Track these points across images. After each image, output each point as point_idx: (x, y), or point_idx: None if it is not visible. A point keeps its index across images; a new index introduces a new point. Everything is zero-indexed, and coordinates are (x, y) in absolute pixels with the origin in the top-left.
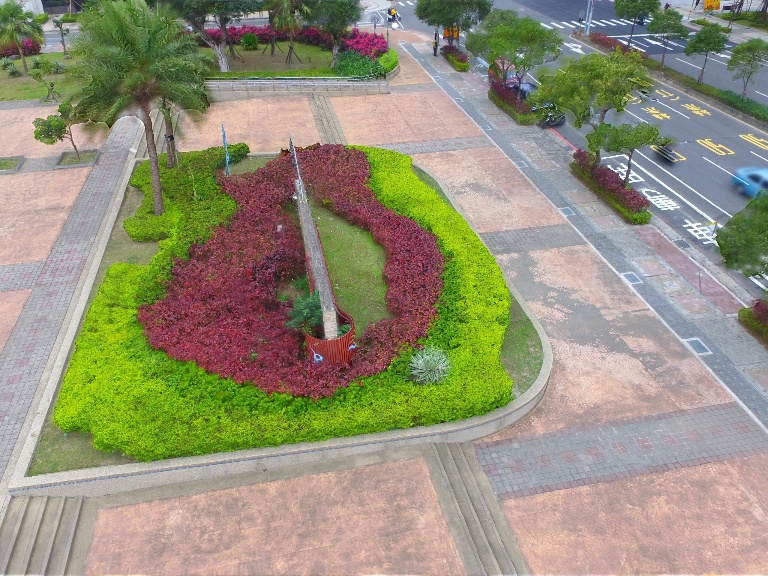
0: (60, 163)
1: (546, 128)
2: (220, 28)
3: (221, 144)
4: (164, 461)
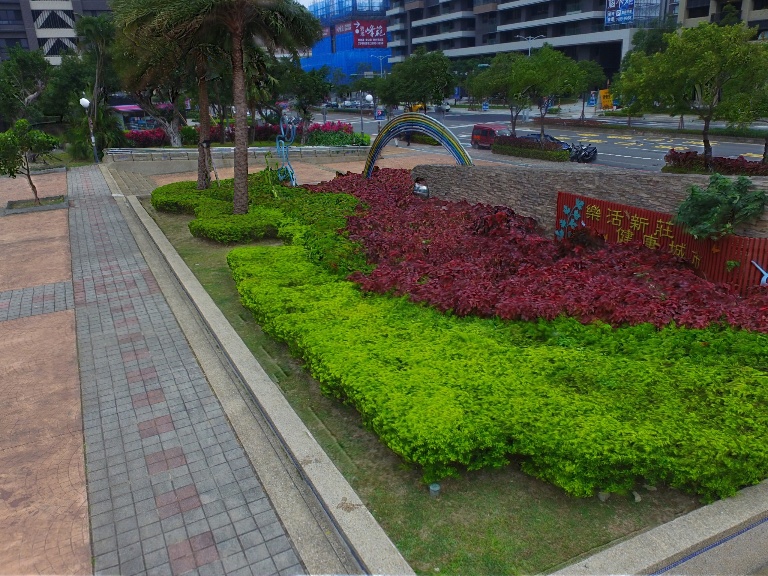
0: None
1: None
2: (171, 103)
3: None
4: (760, 487)
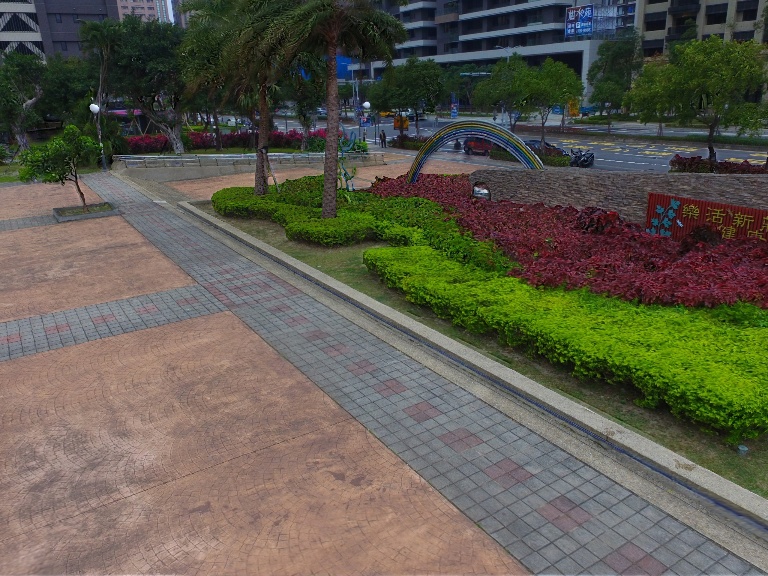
0: None
1: None
2: (173, 109)
3: None
4: None
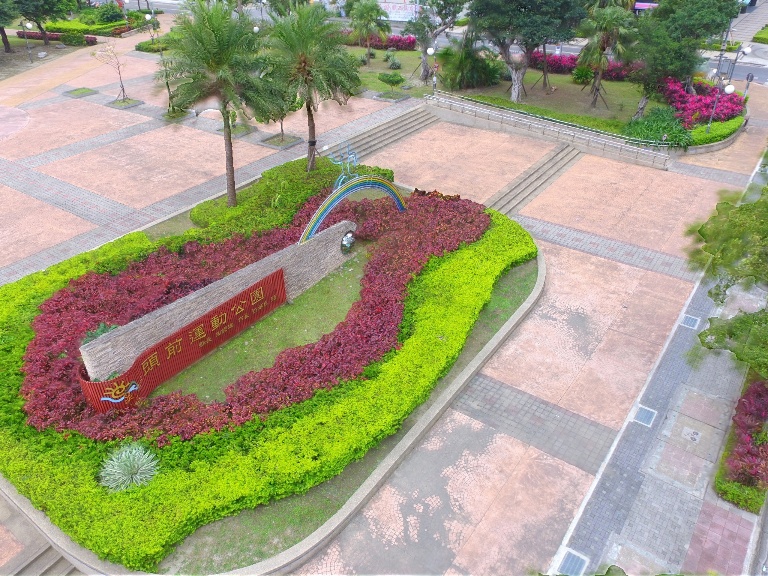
0: (266, 140)
1: None
2: (525, 53)
3: (405, 166)
4: None
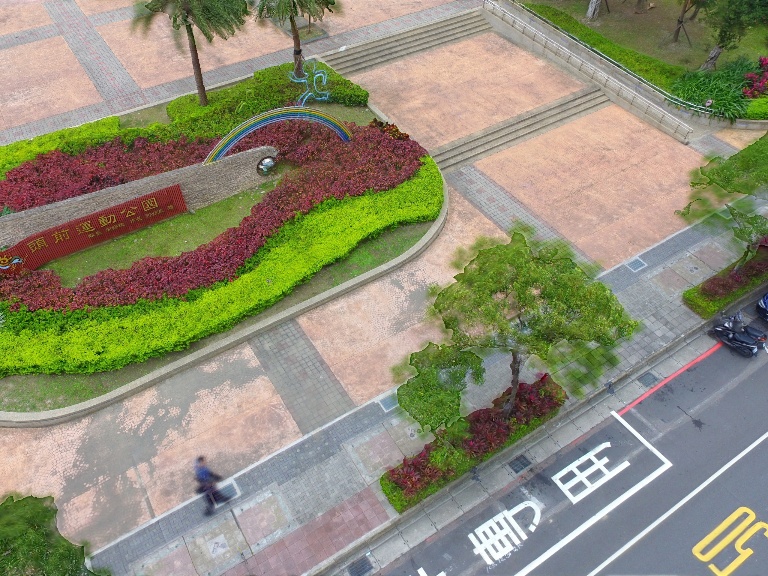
0: None
1: (714, 337)
2: None
3: (407, 84)
4: None
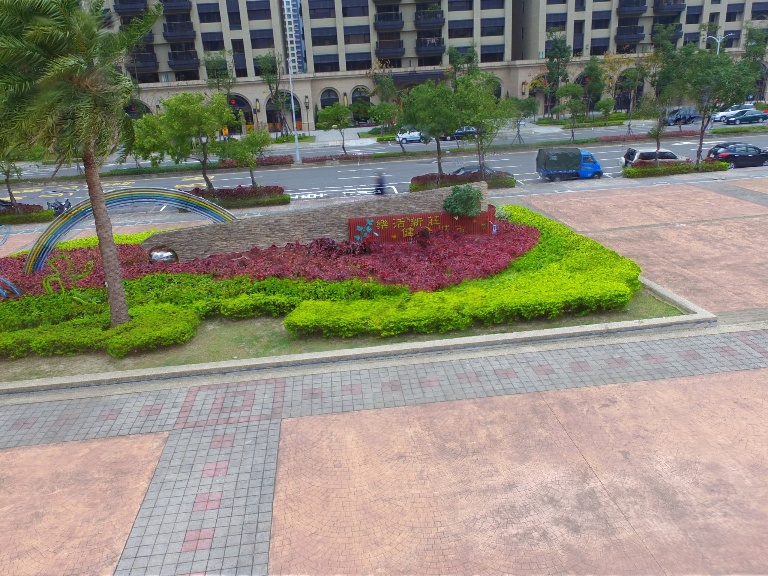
0: None
1: None
2: None
3: None
4: None
